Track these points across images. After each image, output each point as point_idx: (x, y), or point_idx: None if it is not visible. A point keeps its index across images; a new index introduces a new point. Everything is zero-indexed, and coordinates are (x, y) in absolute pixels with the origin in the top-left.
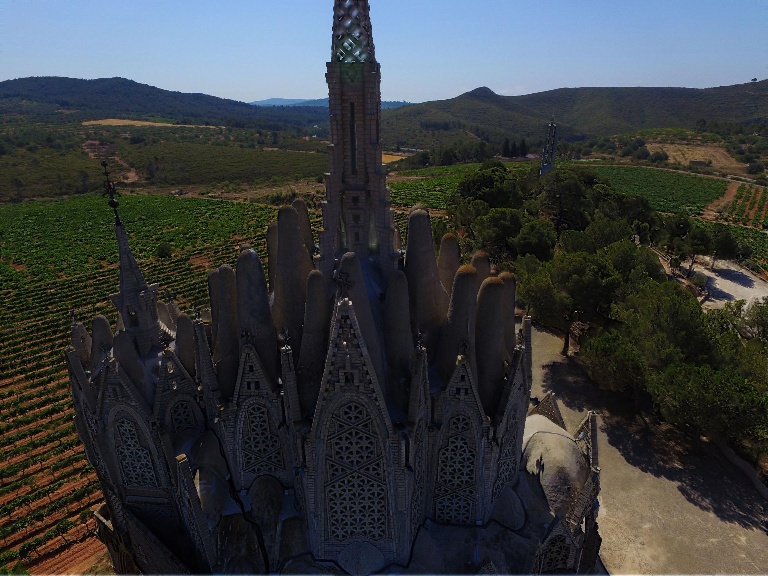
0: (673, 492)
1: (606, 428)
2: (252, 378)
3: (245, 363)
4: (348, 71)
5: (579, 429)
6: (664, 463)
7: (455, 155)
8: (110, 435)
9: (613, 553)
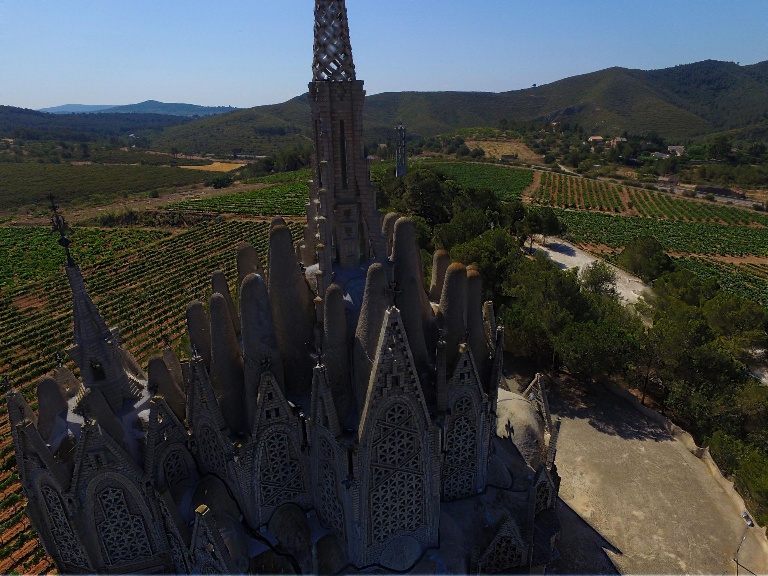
0: (587, 427)
1: (523, 389)
2: (271, 406)
3: (264, 392)
4: (336, 90)
5: (528, 391)
6: (573, 406)
7: (299, 160)
8: (88, 512)
9: (564, 487)
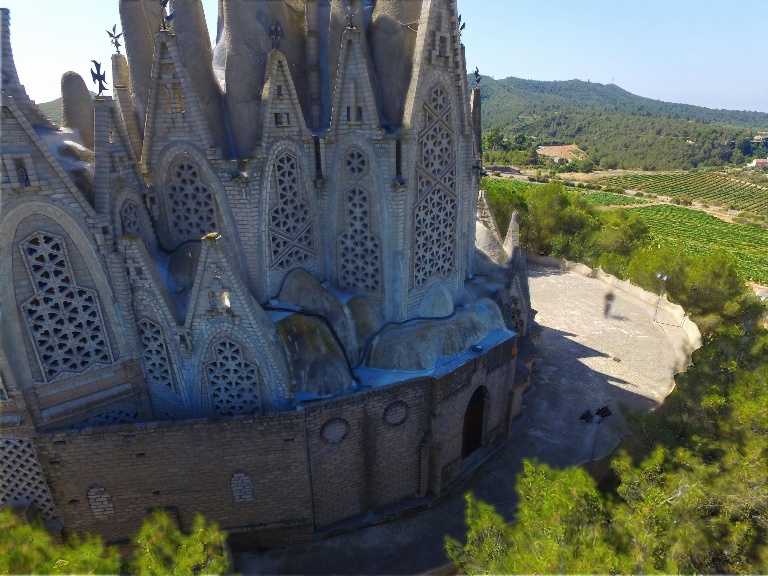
0: None
1: None
2: (281, 108)
3: None
4: None
5: None
6: None
7: None
8: (3, 279)
9: None
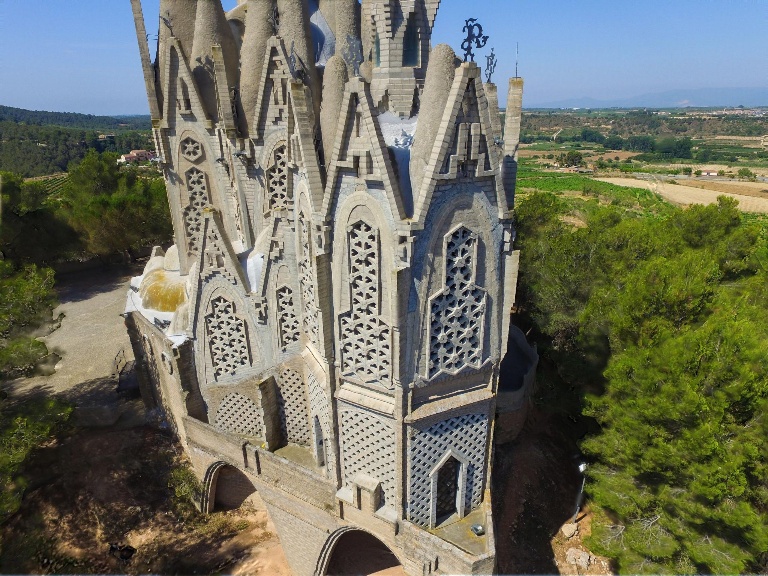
0: None
1: None
2: None
3: None
4: None
5: None
6: None
7: None
8: None
9: None
